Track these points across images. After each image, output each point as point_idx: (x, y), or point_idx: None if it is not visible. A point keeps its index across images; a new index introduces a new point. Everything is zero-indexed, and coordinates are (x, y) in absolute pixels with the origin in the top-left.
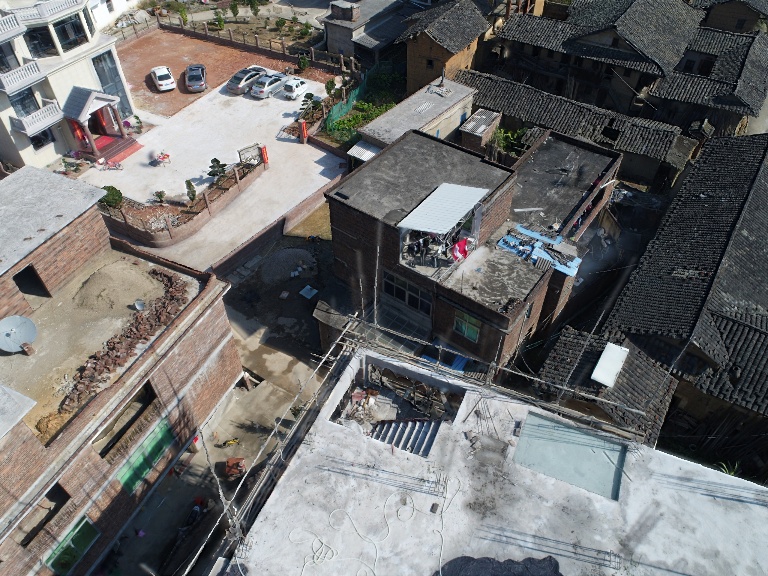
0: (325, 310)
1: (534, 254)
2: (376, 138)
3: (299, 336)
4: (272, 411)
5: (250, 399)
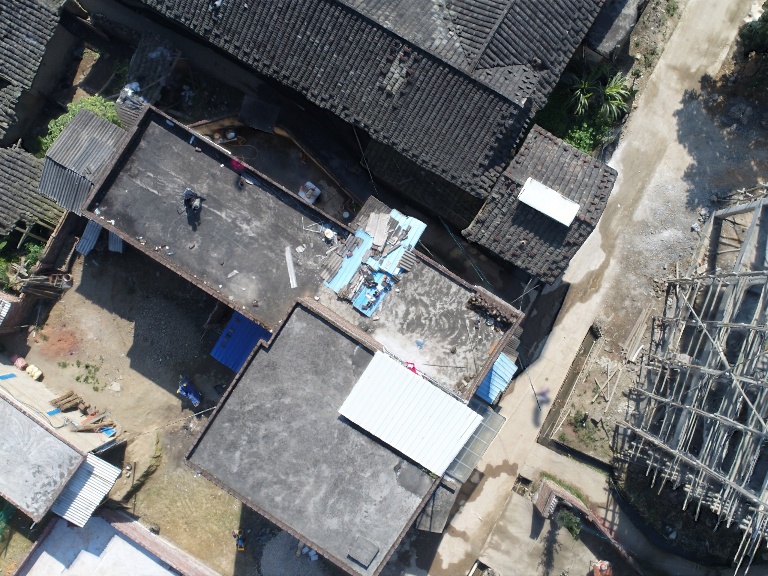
0: (429, 518)
1: (393, 272)
2: (62, 488)
3: (414, 532)
4: (523, 545)
5: (509, 571)
